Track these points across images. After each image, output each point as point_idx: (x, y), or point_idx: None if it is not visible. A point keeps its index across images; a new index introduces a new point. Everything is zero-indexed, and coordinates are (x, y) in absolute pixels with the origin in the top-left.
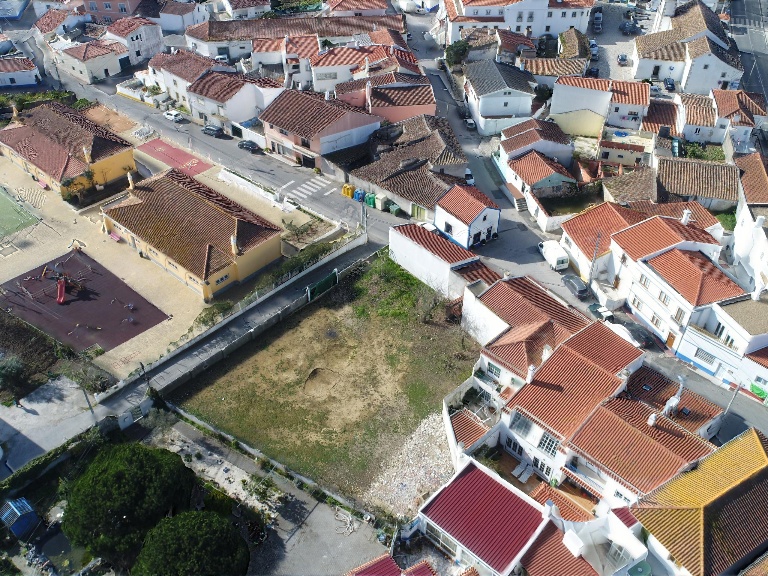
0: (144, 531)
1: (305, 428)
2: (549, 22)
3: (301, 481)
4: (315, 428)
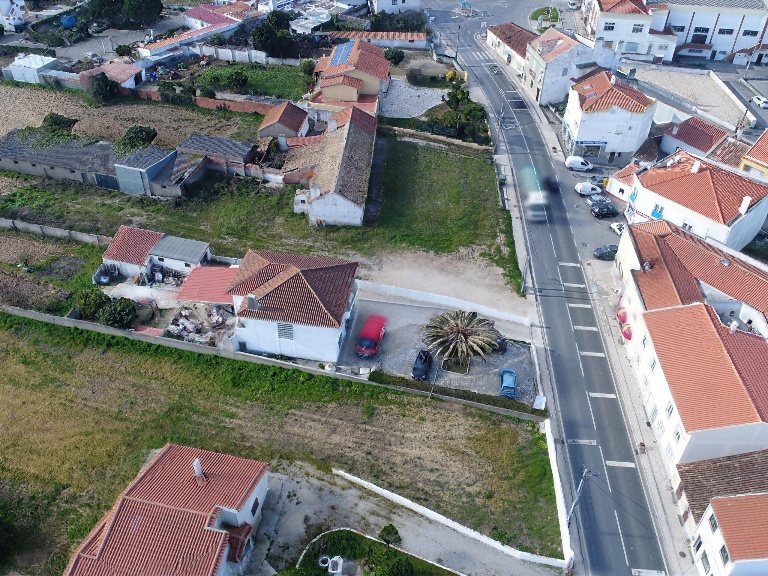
0: (122, 5)
1: (172, 3)
2: None
3: (175, 8)
4: (176, 3)
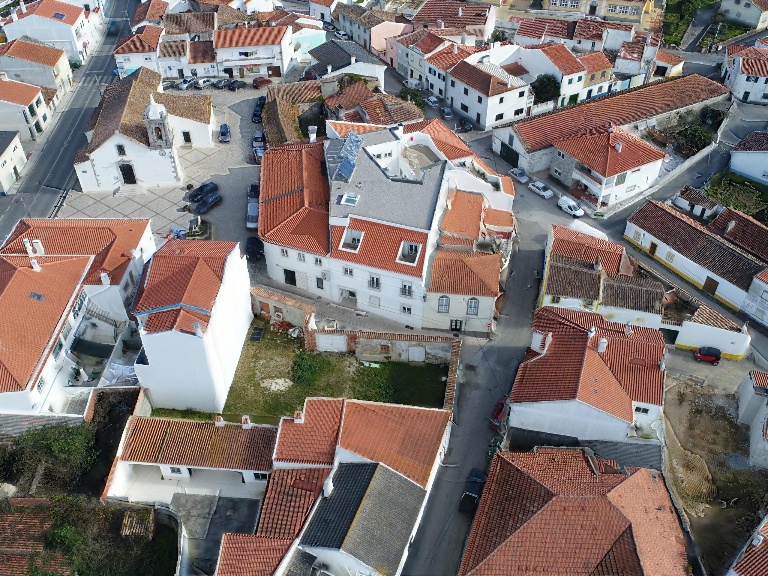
0: None
1: None
2: None
3: None
4: None
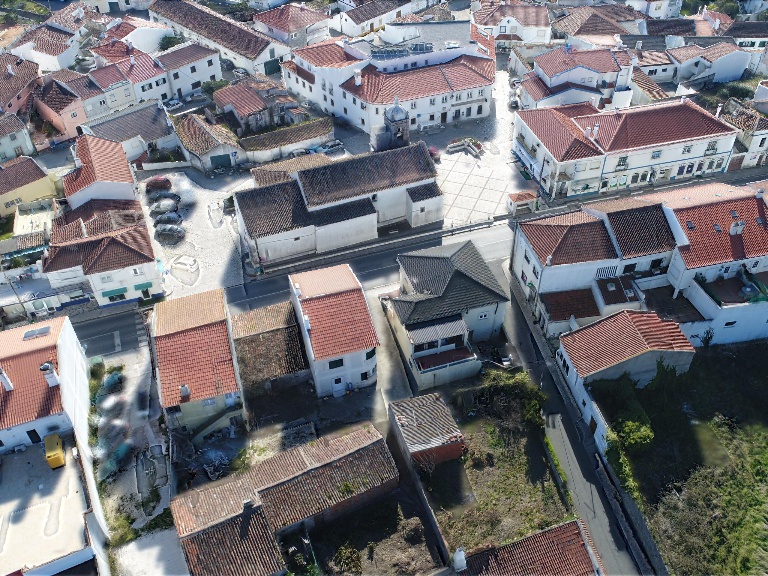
0: None
1: None
2: (345, 103)
3: None
4: None
